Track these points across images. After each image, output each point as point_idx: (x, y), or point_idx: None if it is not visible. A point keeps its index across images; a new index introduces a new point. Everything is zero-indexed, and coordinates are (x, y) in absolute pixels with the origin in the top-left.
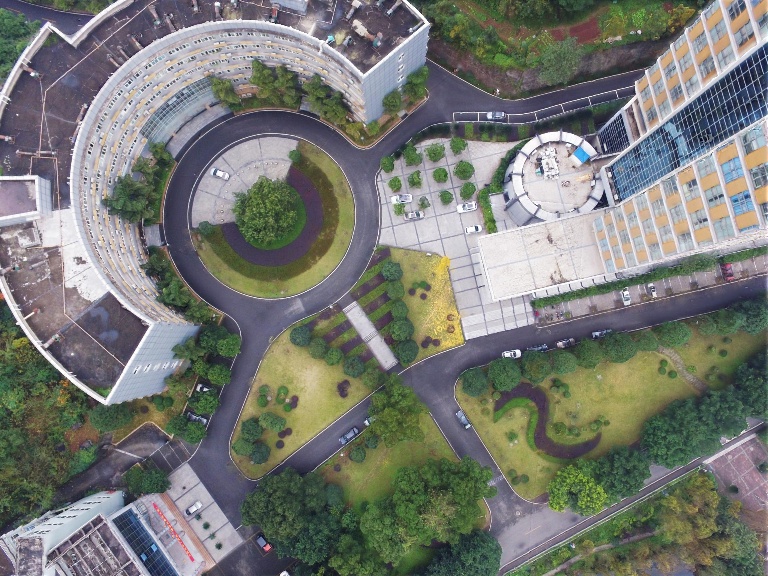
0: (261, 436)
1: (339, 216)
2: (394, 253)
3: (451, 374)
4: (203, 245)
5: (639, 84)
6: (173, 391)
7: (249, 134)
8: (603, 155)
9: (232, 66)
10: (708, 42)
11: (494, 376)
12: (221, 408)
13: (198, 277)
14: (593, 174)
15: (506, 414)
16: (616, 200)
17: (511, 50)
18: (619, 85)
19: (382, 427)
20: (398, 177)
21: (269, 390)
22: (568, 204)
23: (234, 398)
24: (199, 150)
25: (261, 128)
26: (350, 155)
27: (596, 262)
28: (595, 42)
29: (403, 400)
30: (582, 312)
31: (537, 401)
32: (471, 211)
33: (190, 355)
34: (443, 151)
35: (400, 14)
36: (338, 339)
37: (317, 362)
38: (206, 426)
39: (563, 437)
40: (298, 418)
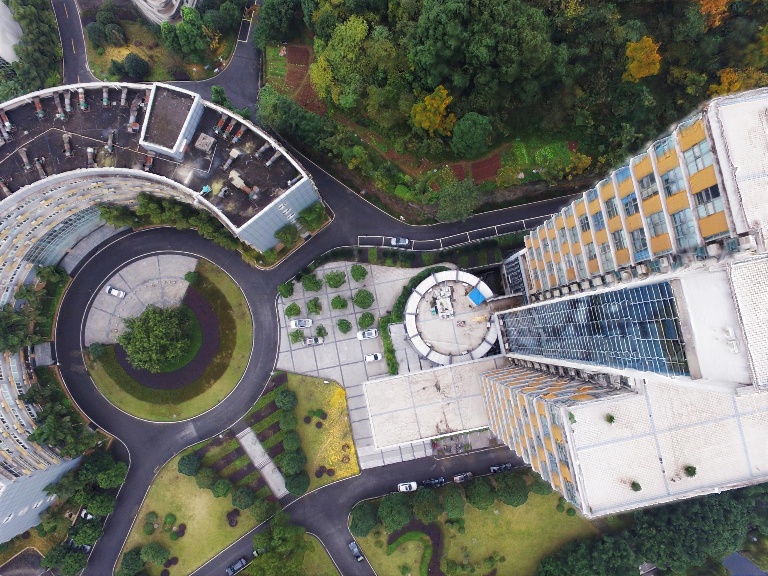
0: (143, 568)
1: (236, 339)
2: (291, 379)
3: (345, 504)
4: (95, 365)
5: (527, 241)
6: (47, 527)
7: (148, 251)
8: (500, 296)
9: (119, 196)
10: (567, 240)
11: (383, 516)
12: (106, 534)
13: (89, 397)
14: (490, 314)
15: (400, 547)
16: (507, 349)
17: (411, 183)
18: (527, 215)
19: (259, 573)
20: (299, 300)
21: (154, 520)
22: (463, 345)
23: (120, 524)
24: (96, 266)
25: (160, 245)
26: (251, 275)
27: (483, 412)
28: (496, 179)
29: (282, 545)
30: (482, 445)
31: (431, 535)
32: (372, 338)
33: (65, 492)
34: (343, 278)
35: (280, 164)
36: (229, 466)
37: (207, 490)
38: (90, 552)
39: (457, 572)
40: (185, 547)
